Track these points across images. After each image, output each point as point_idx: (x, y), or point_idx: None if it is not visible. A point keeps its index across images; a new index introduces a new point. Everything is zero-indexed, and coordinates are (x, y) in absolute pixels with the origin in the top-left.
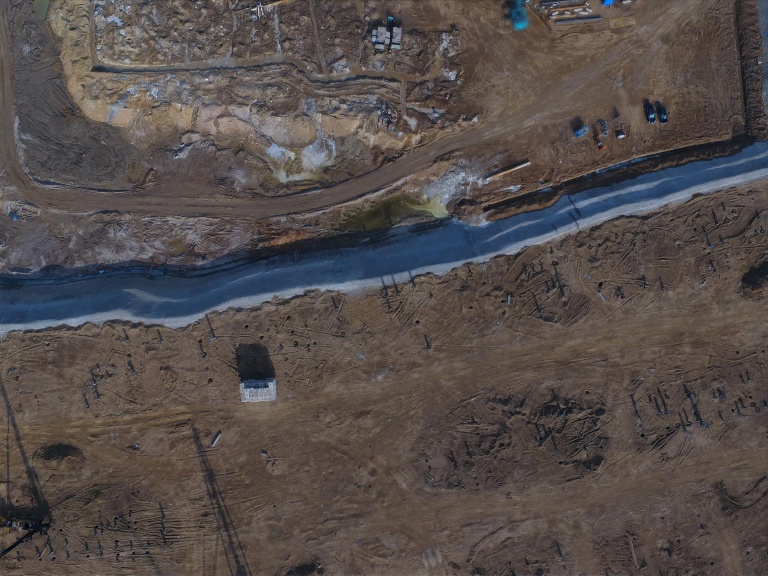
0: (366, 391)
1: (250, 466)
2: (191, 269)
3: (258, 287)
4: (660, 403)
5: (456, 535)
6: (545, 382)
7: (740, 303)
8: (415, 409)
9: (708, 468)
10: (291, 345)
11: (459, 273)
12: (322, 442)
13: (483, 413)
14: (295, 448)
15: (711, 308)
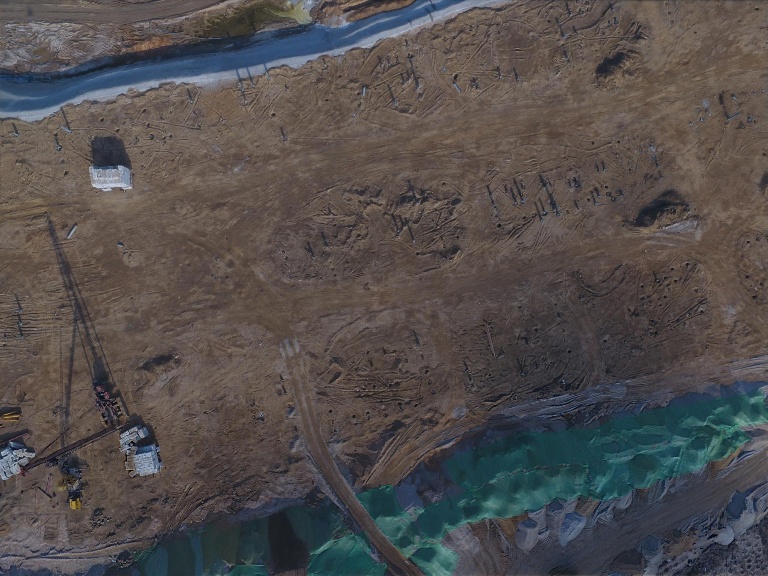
0: (222, 183)
1: (107, 258)
2: (56, 77)
3: (114, 82)
4: (516, 193)
5: (314, 326)
6: (401, 173)
7: (595, 94)
8: (272, 201)
9: (565, 257)
10: (147, 138)
11: (314, 66)
12: (179, 234)
13: (339, 204)
14: (152, 240)
15: (566, 99)
